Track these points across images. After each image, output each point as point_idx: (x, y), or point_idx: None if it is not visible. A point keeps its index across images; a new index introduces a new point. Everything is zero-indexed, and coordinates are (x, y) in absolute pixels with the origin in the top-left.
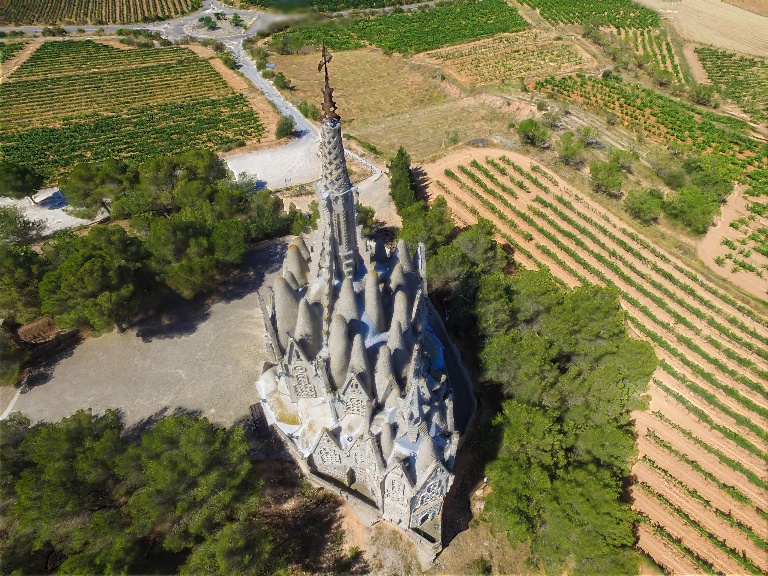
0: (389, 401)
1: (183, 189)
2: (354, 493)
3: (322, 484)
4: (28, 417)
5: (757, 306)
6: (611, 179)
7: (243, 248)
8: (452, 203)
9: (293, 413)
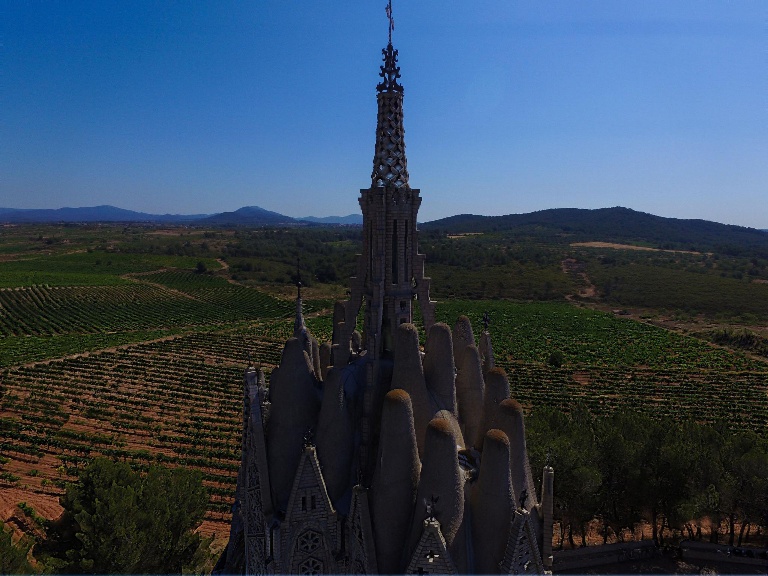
0: None
1: None
2: None
3: None
4: None
5: None
6: None
7: None
8: None
9: None
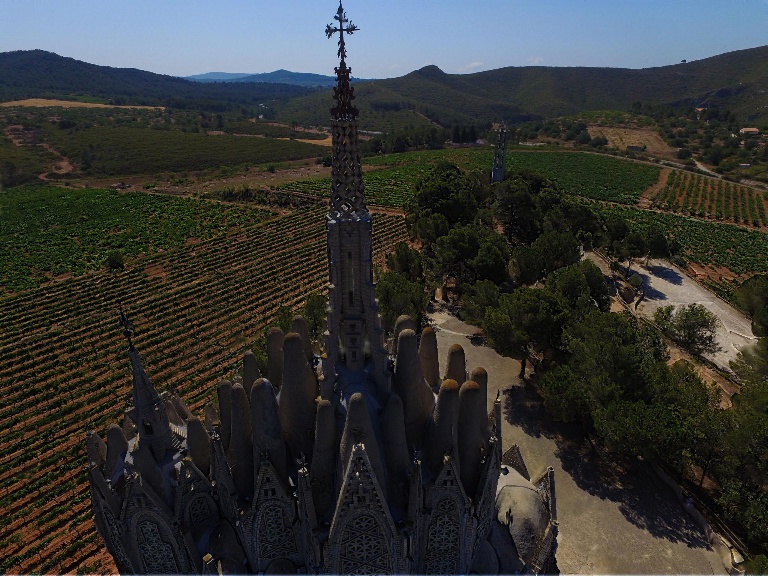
0: None
1: (761, 394)
2: None
3: None
4: (443, 339)
5: None
6: None
7: (619, 437)
8: None
9: None
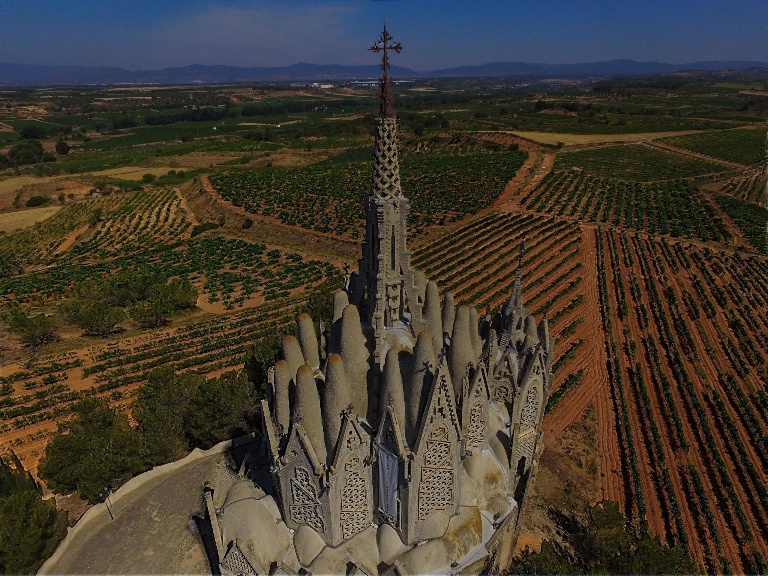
0: (495, 349)
1: None
2: (517, 497)
3: (518, 529)
4: None
5: (286, 299)
6: (113, 314)
7: None
8: (21, 451)
9: (473, 511)
